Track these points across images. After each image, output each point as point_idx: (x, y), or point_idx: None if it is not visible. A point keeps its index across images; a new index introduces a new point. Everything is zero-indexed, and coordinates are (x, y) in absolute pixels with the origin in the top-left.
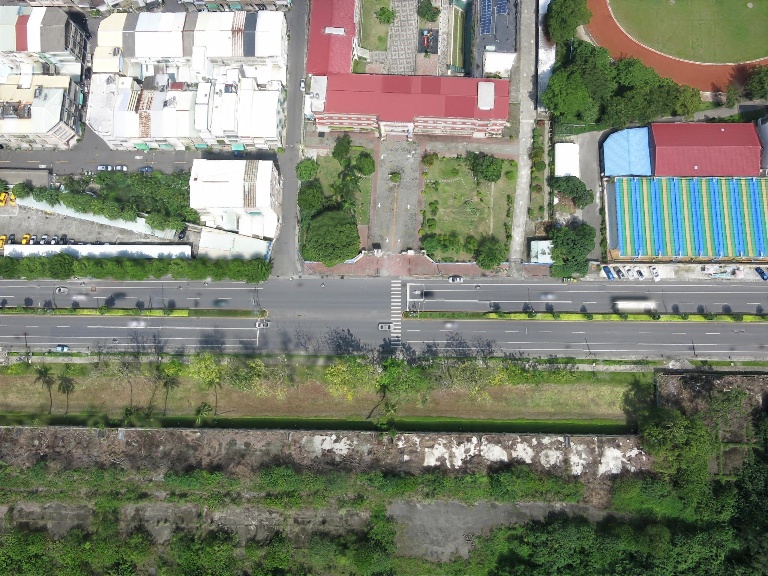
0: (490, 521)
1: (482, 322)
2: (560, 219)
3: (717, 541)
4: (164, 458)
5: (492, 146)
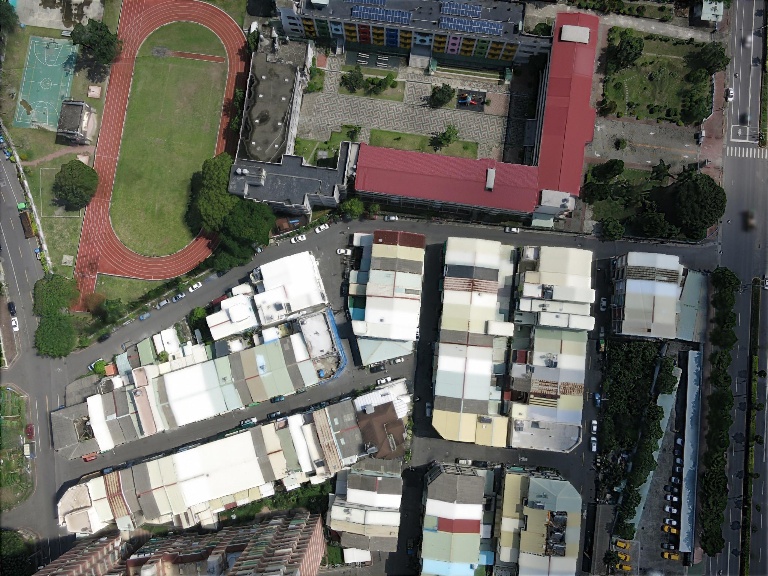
0: None
1: None
2: None
3: None
4: None
5: None
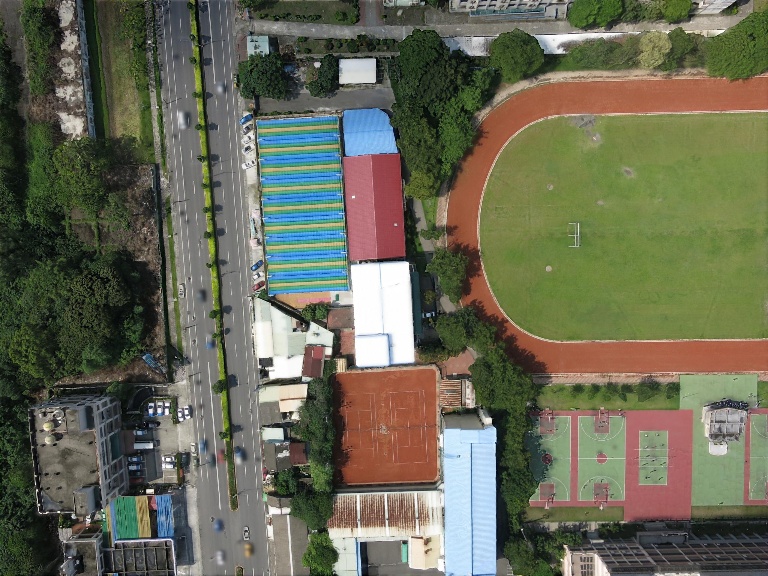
0: (5, 12)
1: None
2: (299, 71)
3: (7, 208)
4: None
5: None
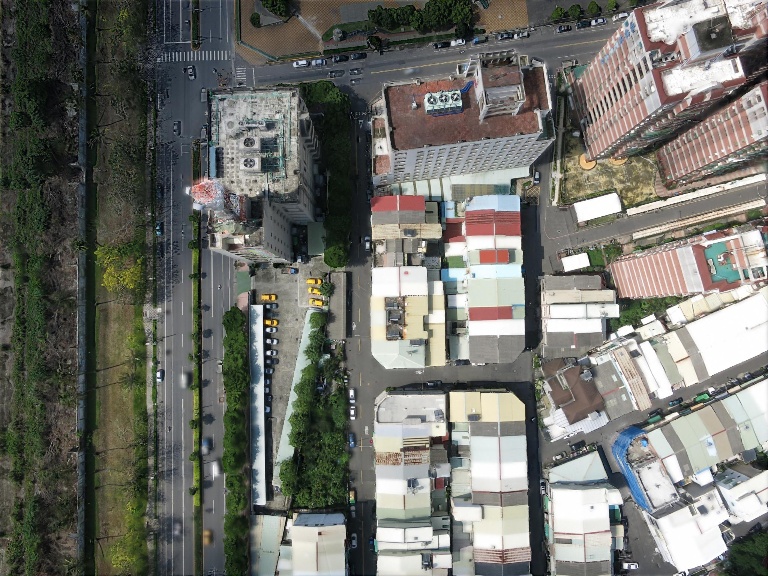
0: None
1: None
2: None
3: None
4: (54, 495)
5: None
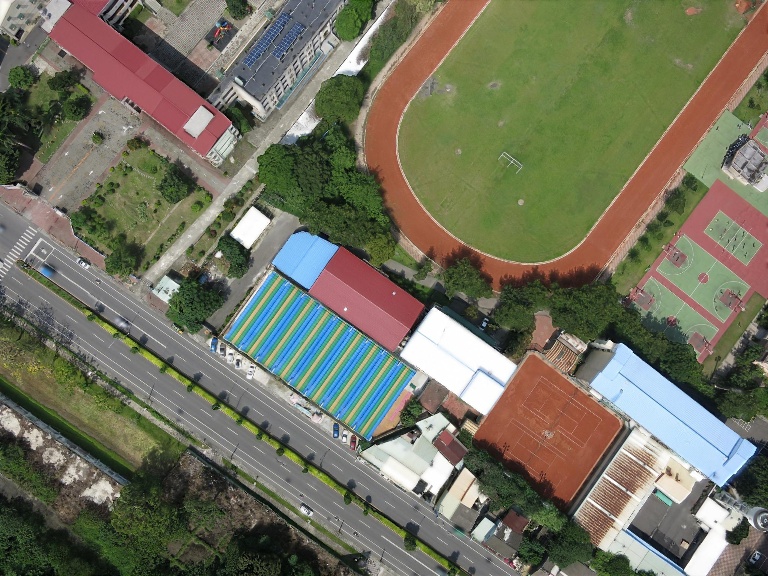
0: None
1: (79, 313)
2: (212, 273)
3: None
4: None
5: (203, 170)
